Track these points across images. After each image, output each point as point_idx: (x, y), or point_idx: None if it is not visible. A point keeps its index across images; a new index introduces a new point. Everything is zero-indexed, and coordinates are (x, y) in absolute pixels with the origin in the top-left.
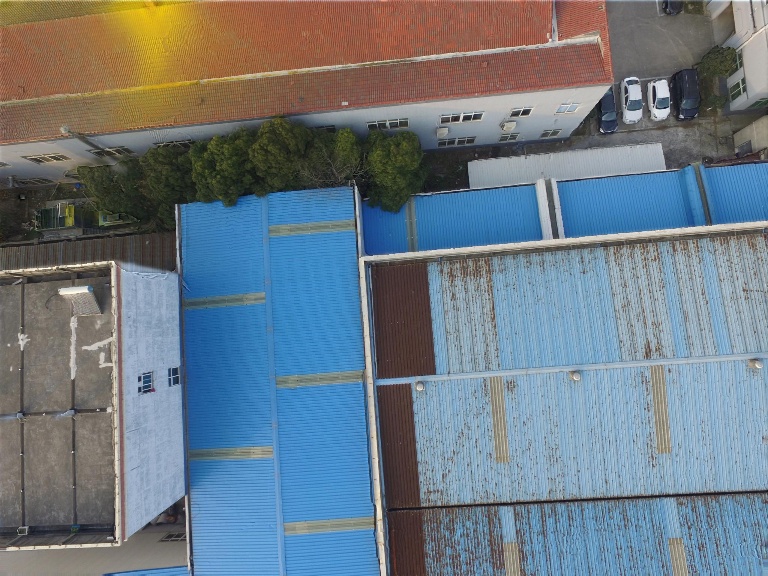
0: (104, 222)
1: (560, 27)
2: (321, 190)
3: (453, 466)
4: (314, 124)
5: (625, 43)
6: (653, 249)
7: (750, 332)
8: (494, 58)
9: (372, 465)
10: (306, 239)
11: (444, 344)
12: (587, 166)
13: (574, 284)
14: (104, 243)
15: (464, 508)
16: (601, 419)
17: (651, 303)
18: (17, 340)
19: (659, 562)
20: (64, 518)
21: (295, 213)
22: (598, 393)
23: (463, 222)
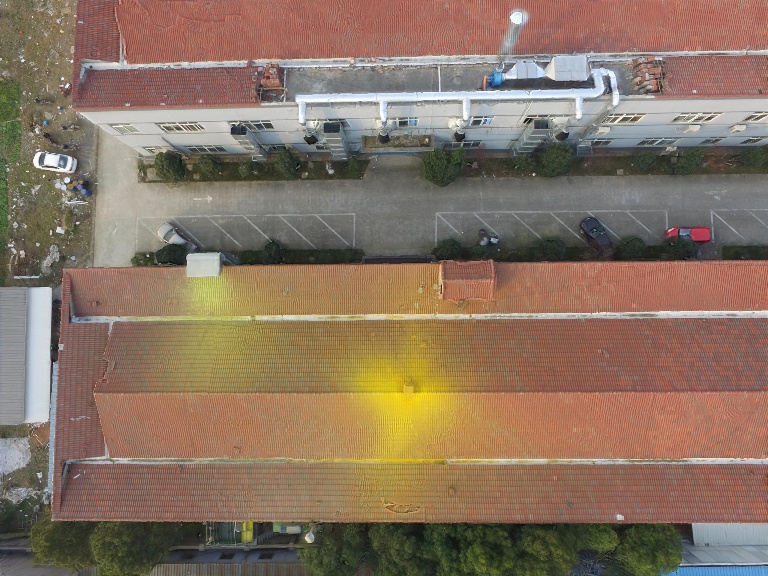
0: (281, 532)
1: None
2: None
3: None
4: None
5: None
6: None
7: None
8: None
9: None
10: None
11: None
12: None
13: None
14: (290, 570)
15: None
16: None
17: None
18: None
19: None
20: None
21: None
22: None
23: None
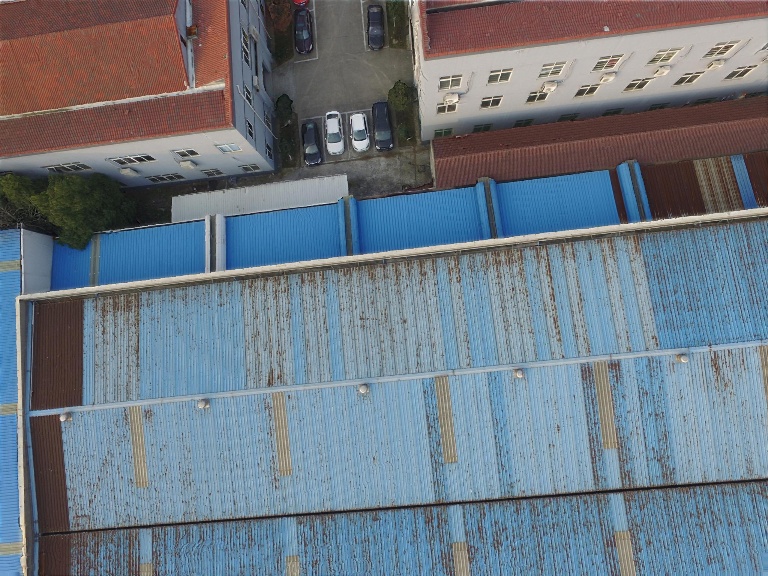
0: None
1: (196, 75)
2: None
3: (98, 492)
4: None
5: (334, 78)
6: (284, 281)
7: (362, 358)
8: (137, 106)
9: (19, 493)
10: None
11: (92, 376)
12: (278, 199)
13: (211, 316)
14: None
15: (109, 531)
16: (229, 444)
17: (277, 333)
18: None
19: None
20: None
21: None
22: (226, 420)
23: (141, 257)
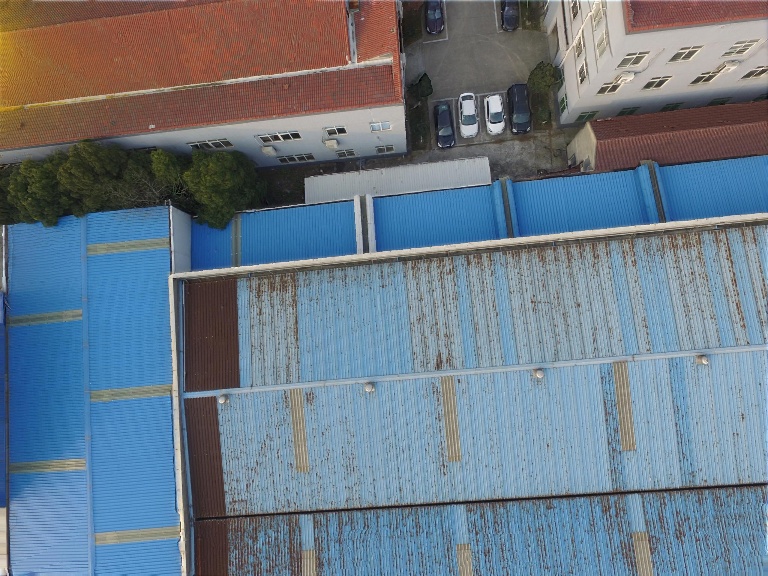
0: None
1: (358, 49)
2: (137, 210)
3: (256, 476)
4: (133, 146)
5: (465, 59)
6: (449, 263)
7: (536, 343)
8: (296, 80)
9: (176, 476)
10: (122, 257)
11: (249, 358)
12: (417, 181)
13: (373, 298)
14: None
15: (267, 517)
16: (395, 429)
17: (444, 315)
18: None
19: (447, 568)
20: None
21: (112, 232)
22: (392, 404)
23: (285, 238)
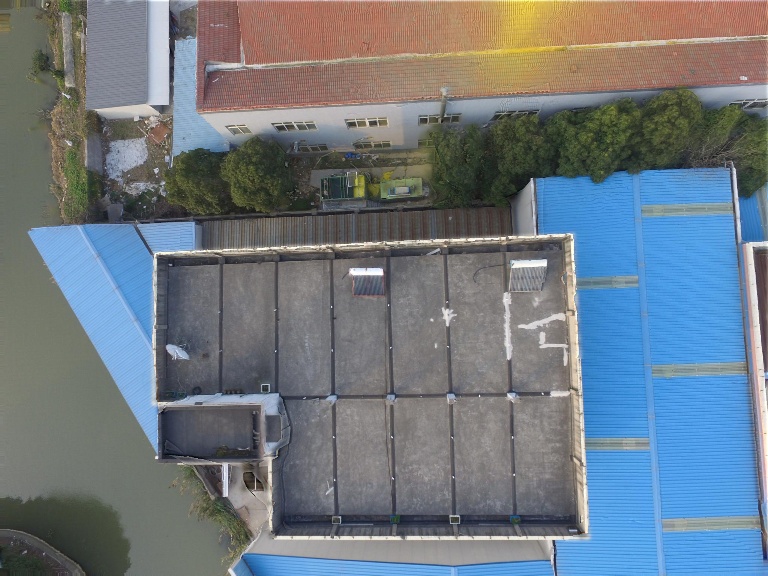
0: (390, 195)
1: None
2: (697, 170)
3: None
4: None
5: None
6: None
7: None
8: None
9: (765, 462)
10: (681, 221)
11: None
12: None
13: None
14: (401, 217)
15: None
16: None
17: None
18: (441, 315)
19: None
20: (501, 508)
21: (669, 193)
22: None
23: None
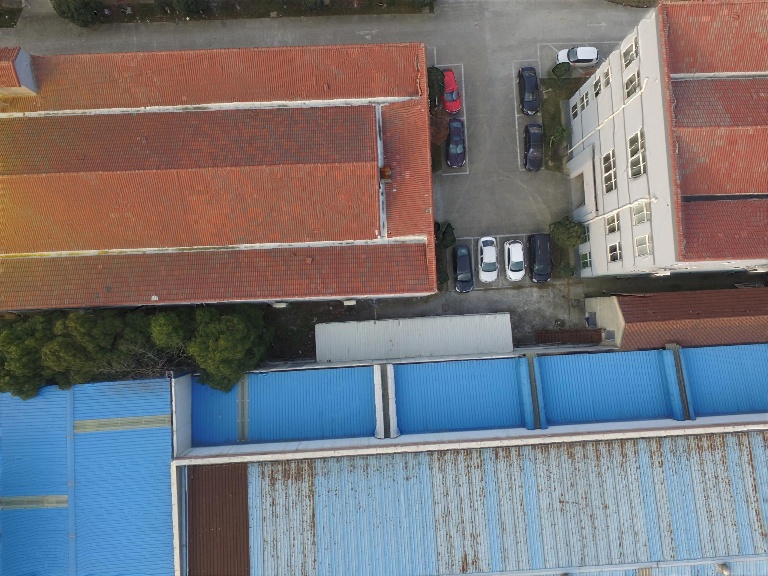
0: None
1: (389, 224)
2: (134, 382)
3: None
4: (129, 307)
5: (486, 197)
6: (476, 456)
7: (563, 546)
8: (320, 253)
9: None
10: (116, 436)
11: (260, 554)
12: (436, 335)
13: (396, 491)
14: None
15: None
16: None
17: (471, 513)
18: None
19: None
20: None
21: (104, 407)
22: None
23: (297, 405)
